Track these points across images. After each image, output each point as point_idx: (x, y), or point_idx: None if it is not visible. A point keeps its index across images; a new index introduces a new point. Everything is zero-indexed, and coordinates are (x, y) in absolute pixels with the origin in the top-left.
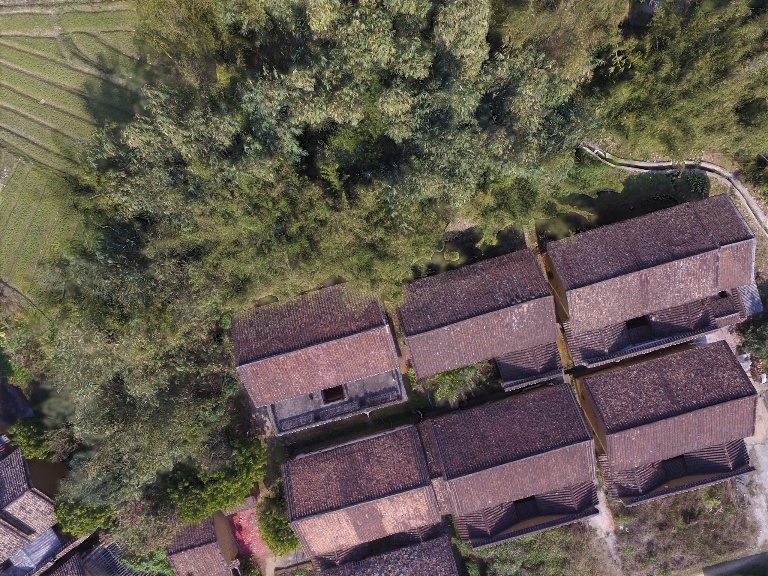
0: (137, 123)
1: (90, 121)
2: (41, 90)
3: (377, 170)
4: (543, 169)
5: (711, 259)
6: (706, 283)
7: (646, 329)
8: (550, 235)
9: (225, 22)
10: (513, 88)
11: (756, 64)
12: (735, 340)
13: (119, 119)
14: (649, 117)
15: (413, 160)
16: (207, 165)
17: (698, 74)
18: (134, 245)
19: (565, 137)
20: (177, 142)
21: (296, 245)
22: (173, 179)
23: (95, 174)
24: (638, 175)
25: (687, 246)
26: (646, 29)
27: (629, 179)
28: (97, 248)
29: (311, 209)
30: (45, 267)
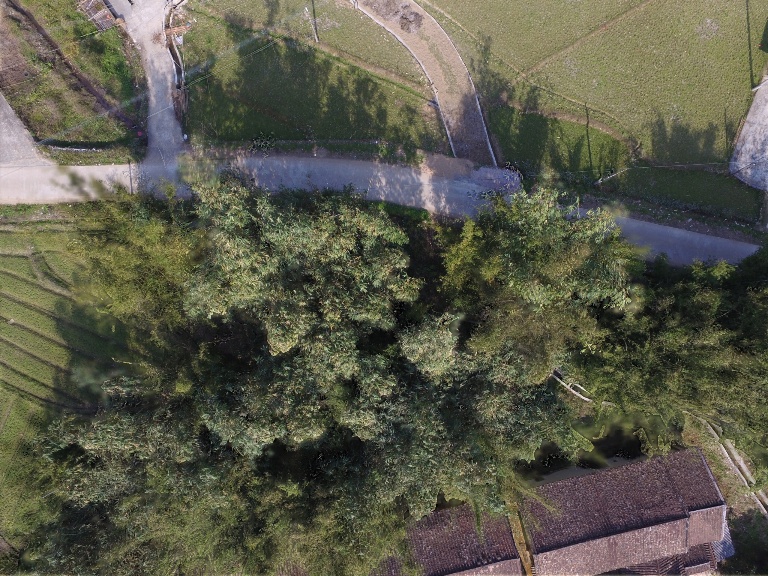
0: (93, 433)
1: (59, 342)
2: (11, 310)
3: (340, 459)
4: (503, 505)
5: (680, 525)
6: (675, 543)
7: (615, 573)
8: (522, 460)
9: (189, 314)
10: (481, 379)
11: (723, 396)
12: (707, 573)
13: (88, 342)
14: (618, 405)
15: (374, 474)
16: (164, 472)
17: (665, 391)
18: (90, 526)
19: (531, 433)
20: (134, 450)
21: (251, 560)
22: (130, 476)
23: (51, 466)
24: (612, 410)
25: (656, 510)
26: (617, 321)
27: (603, 414)
28: (53, 521)
29: (269, 514)
30: (7, 491)
